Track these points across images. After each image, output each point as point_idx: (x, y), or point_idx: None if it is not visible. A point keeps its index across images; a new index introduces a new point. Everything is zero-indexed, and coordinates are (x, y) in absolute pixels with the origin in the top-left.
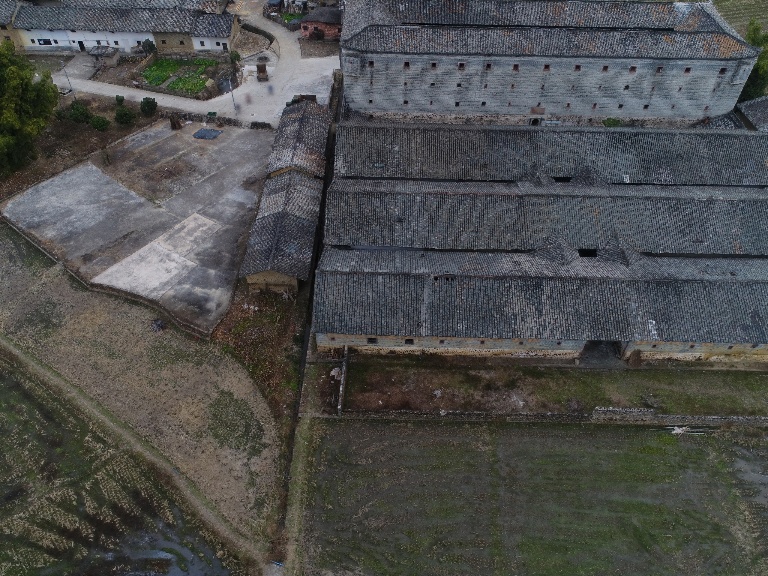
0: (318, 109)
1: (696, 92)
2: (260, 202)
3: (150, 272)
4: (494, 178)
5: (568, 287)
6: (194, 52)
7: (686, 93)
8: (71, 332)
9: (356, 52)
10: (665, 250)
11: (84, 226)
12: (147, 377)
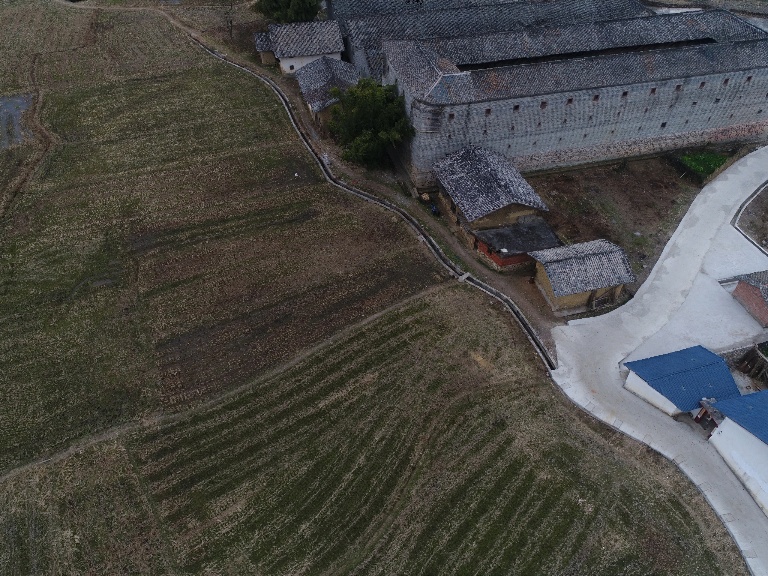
0: None
1: None
2: None
3: None
4: None
5: None
6: None
7: None
8: (679, 0)
9: None
10: None
11: None
12: None
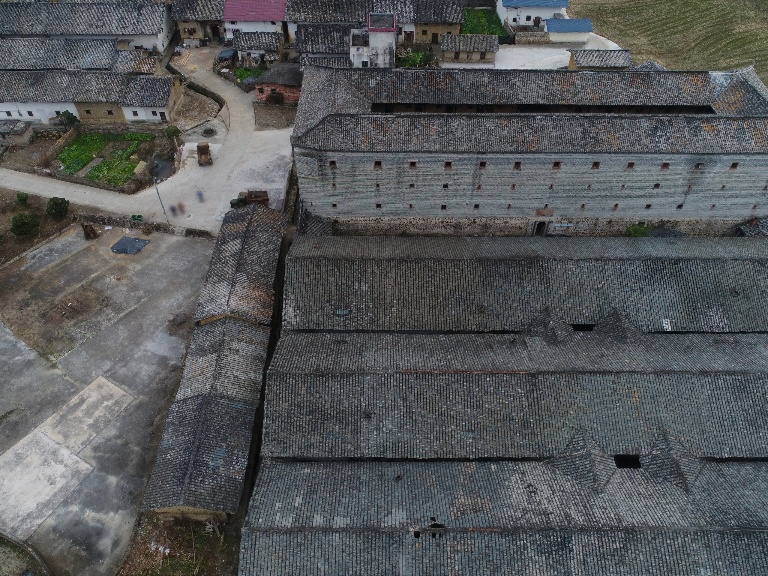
0: (268, 215)
1: (743, 190)
2: (184, 366)
3: (26, 484)
4: (494, 328)
5: (608, 545)
6: (126, 123)
7: (730, 191)
8: None
9: (312, 151)
10: (732, 453)
11: None
12: None
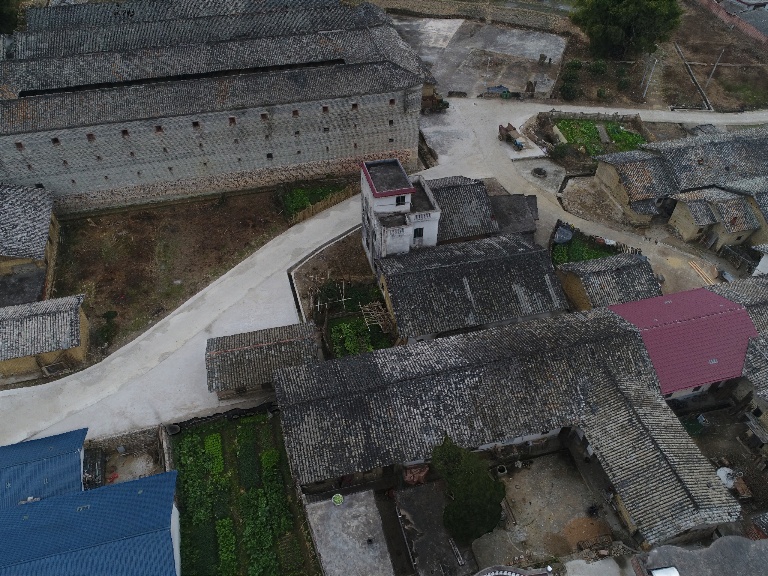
0: None
1: None
2: None
3: (439, 25)
4: None
5: None
6: None
7: None
8: None
9: None
10: None
11: None
12: (402, 4)
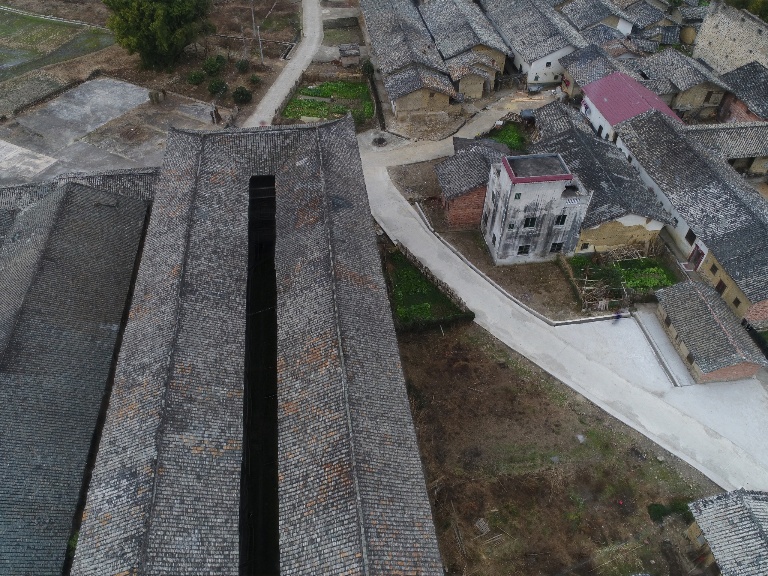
0: None
1: None
2: None
3: None
4: None
5: None
6: None
7: None
8: None
9: None
10: None
11: (59, 114)
12: None
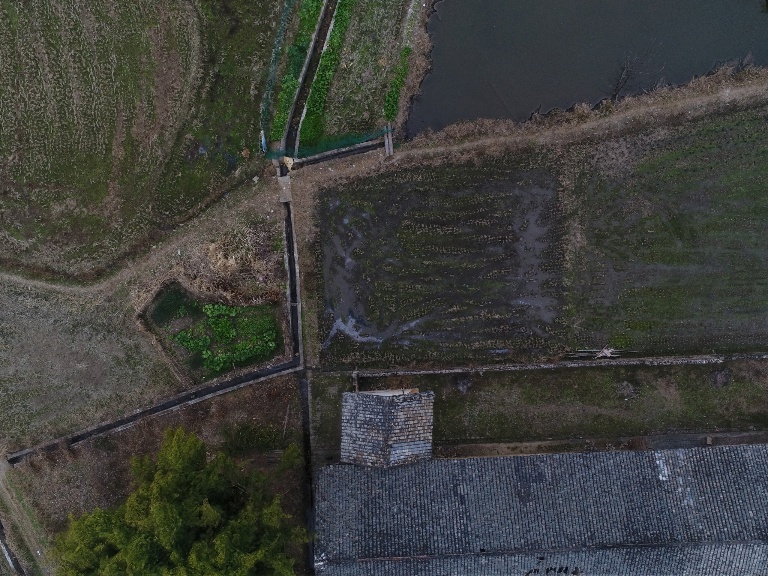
0: None
1: None
2: None
3: None
4: None
5: None
6: None
7: None
8: None
9: None
10: None
11: None
12: None
